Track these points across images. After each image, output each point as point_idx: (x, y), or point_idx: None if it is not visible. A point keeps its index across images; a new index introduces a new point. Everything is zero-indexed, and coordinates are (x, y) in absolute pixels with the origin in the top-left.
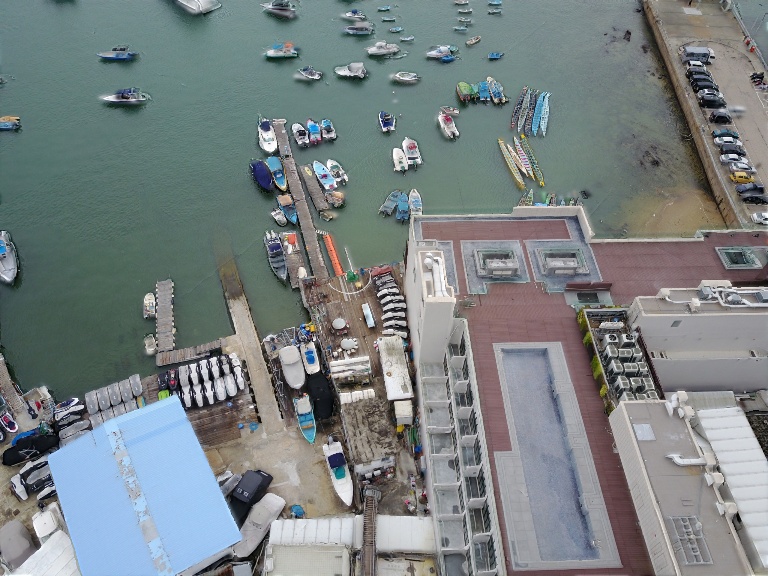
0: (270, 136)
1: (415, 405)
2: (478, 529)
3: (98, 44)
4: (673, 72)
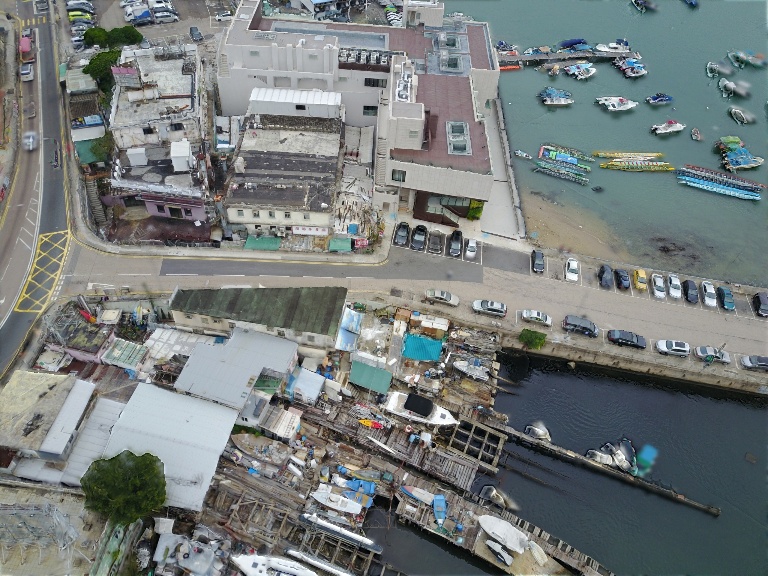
0: (611, 45)
1: None
2: None
3: None
4: None
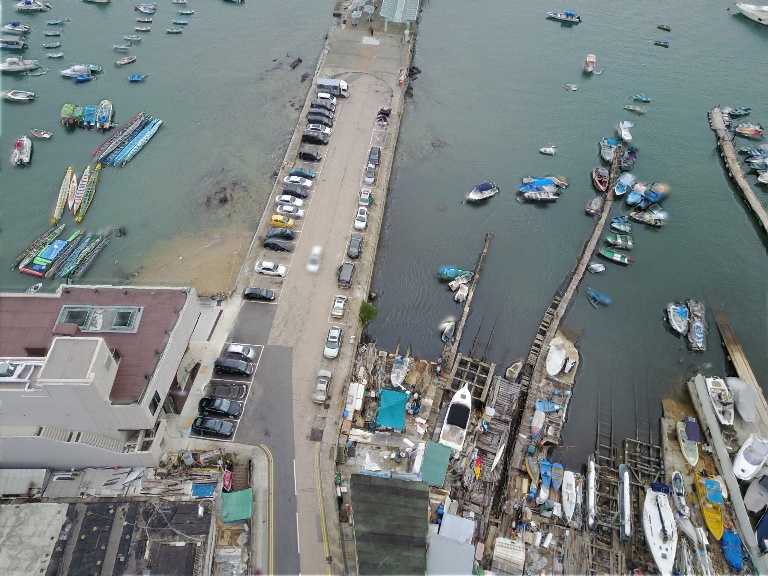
0: None
1: None
2: None
3: None
4: None
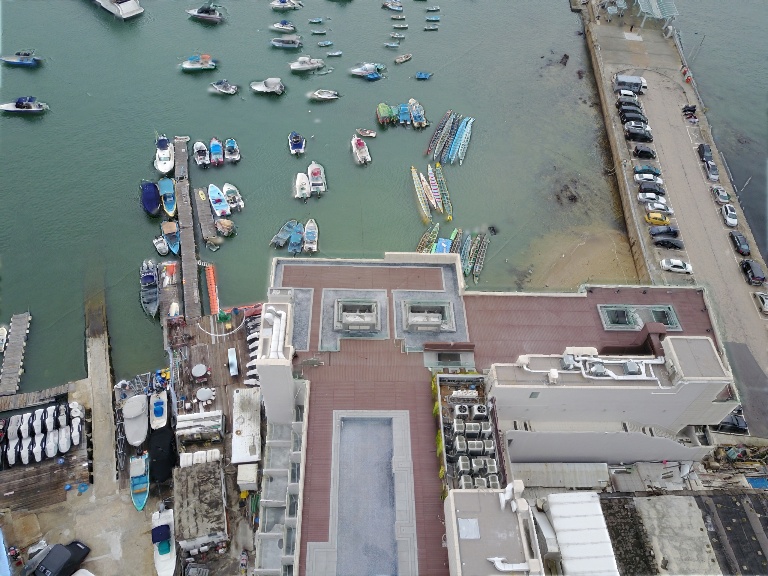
0: (166, 155)
1: (263, 468)
2: None
3: (3, 47)
4: (604, 101)
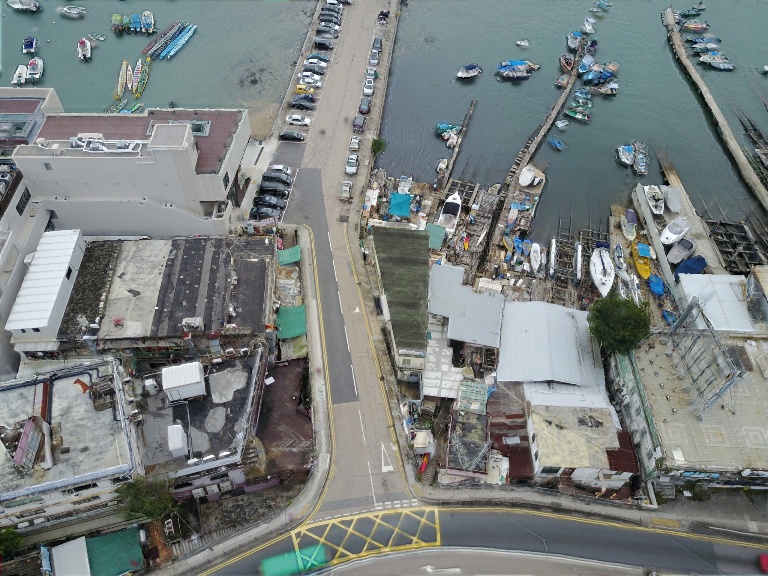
0: None
1: None
2: None
3: None
4: None
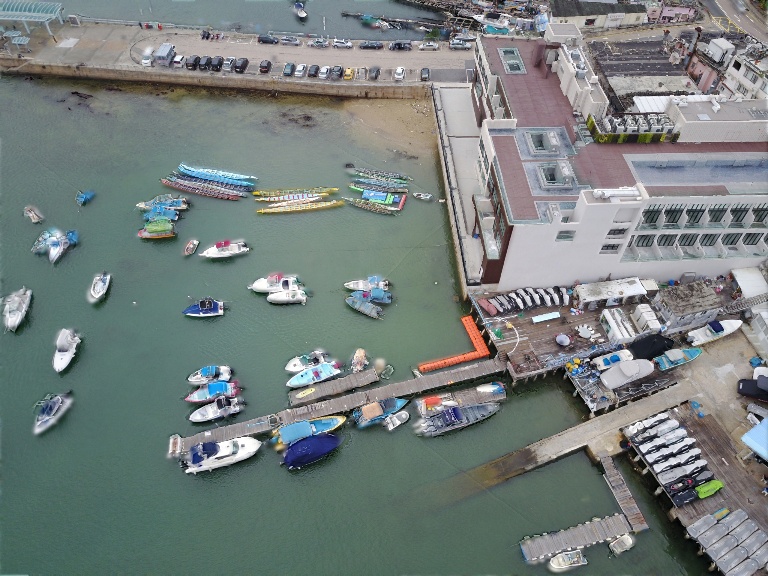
0: (230, 443)
1: None
2: (758, 225)
3: None
4: (176, 77)
